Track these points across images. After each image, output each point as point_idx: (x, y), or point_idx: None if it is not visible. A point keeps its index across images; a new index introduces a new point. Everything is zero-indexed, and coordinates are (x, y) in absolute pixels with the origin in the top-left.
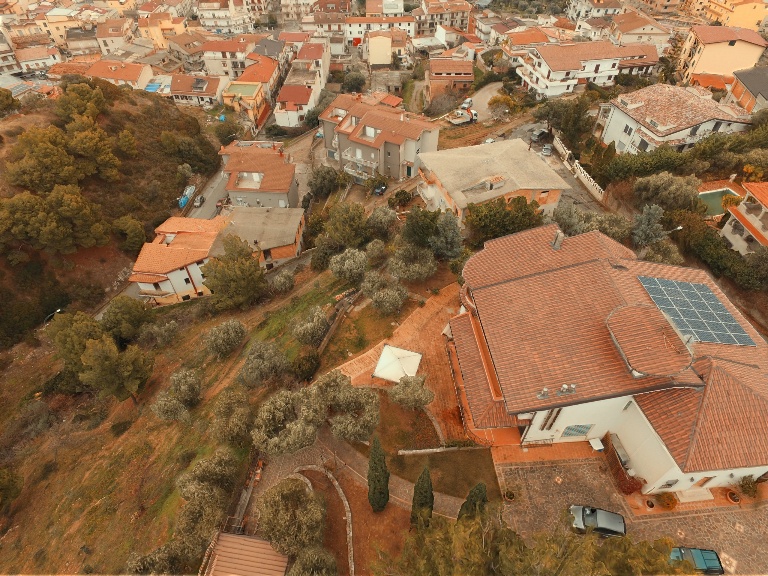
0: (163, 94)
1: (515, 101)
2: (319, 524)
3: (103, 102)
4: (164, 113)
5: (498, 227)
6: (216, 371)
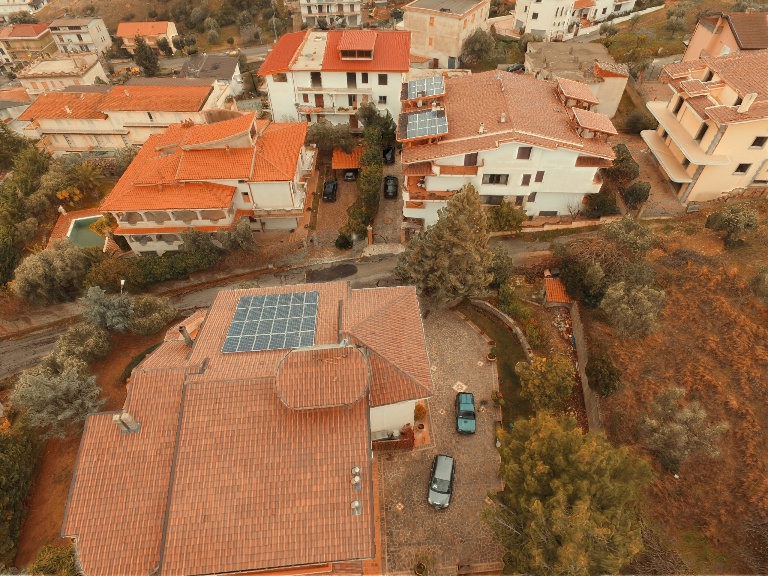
0: None
1: None
2: None
3: None
4: None
5: (3, 498)
6: None
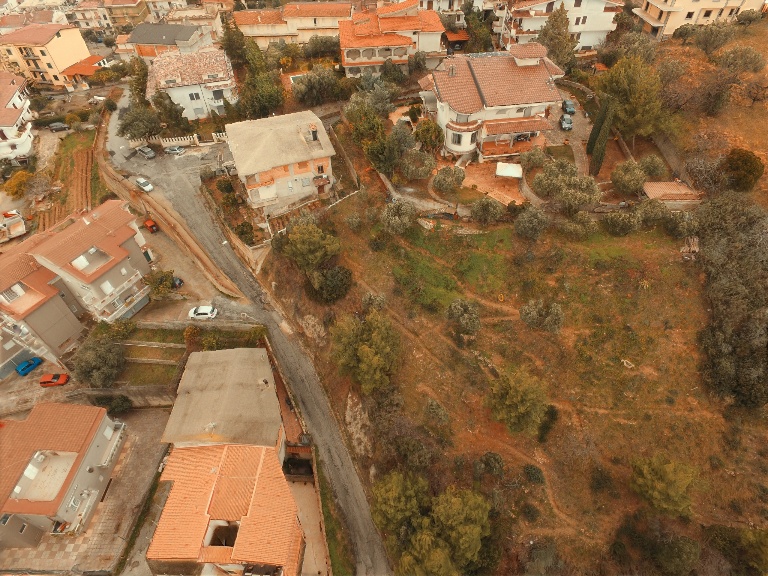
0: None
1: (0, 184)
2: None
3: None
4: None
5: None
6: (487, 333)
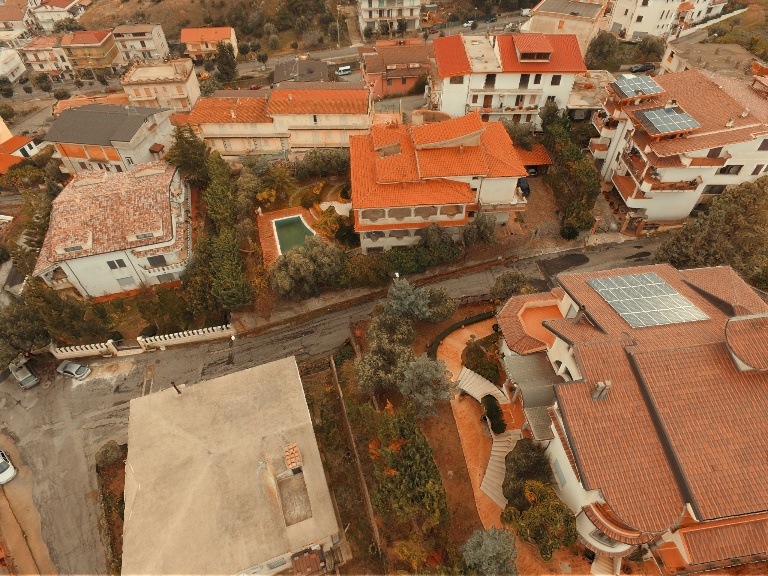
0: None
1: None
2: None
3: None
4: None
5: None
6: None
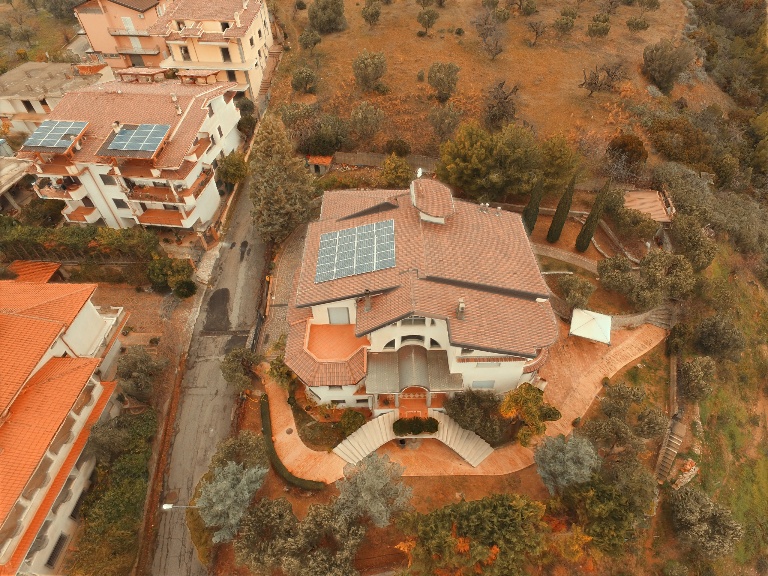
0: None
1: None
2: None
3: None
4: None
5: None
6: None
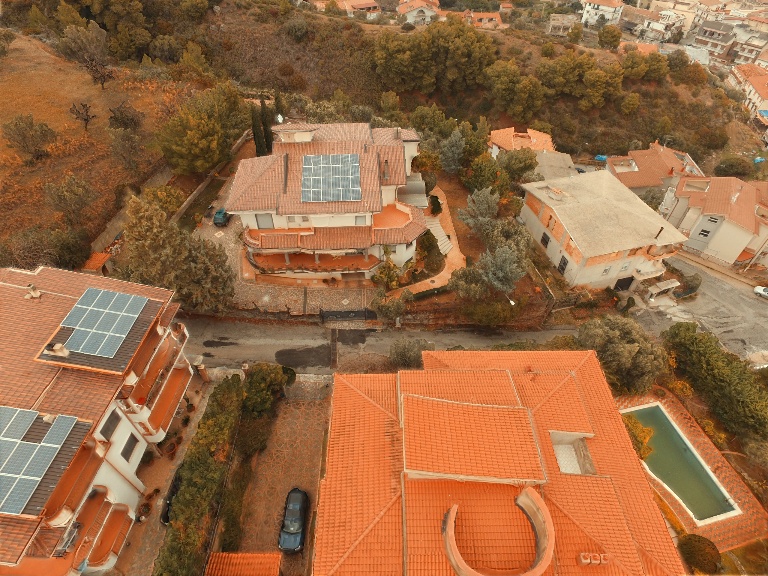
0: (765, 120)
1: None
2: (268, 109)
3: (660, 73)
4: (706, 116)
5: (475, 178)
6: None
